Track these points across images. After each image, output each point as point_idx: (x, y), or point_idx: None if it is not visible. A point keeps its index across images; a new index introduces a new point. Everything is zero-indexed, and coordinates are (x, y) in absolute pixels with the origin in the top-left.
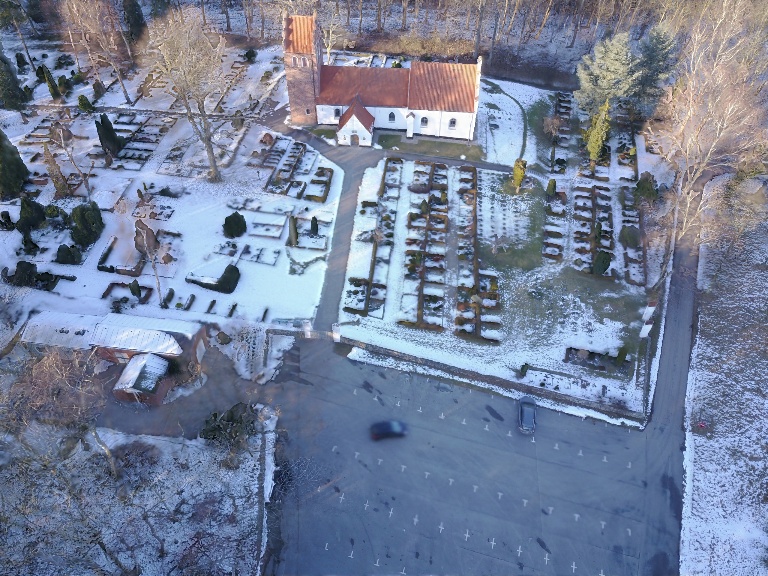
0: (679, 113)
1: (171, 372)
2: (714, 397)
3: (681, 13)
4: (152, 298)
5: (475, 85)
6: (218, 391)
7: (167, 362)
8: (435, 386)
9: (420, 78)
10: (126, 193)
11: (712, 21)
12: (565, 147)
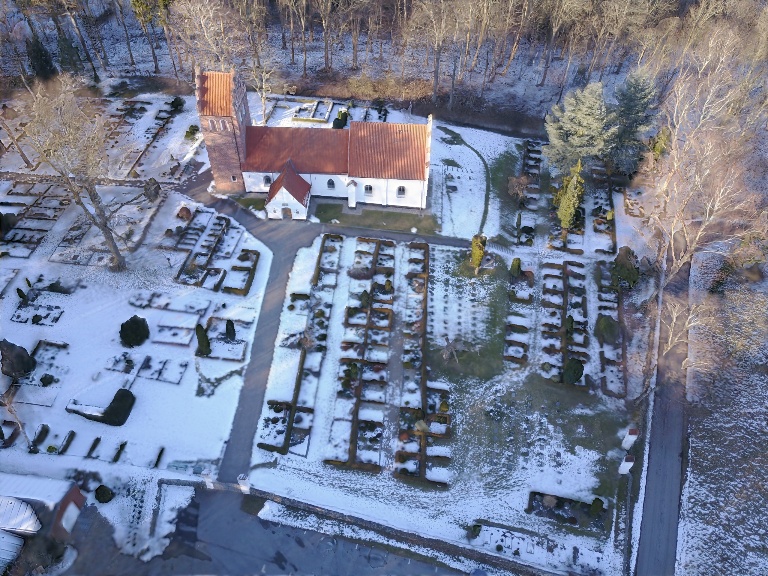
0: (662, 164)
1: (27, 554)
2: (710, 563)
3: (662, 51)
4: (21, 437)
5: (425, 148)
6: (89, 574)
7: (22, 540)
8: (365, 556)
9: (361, 141)
10: (7, 289)
11: (697, 63)
12: (533, 210)
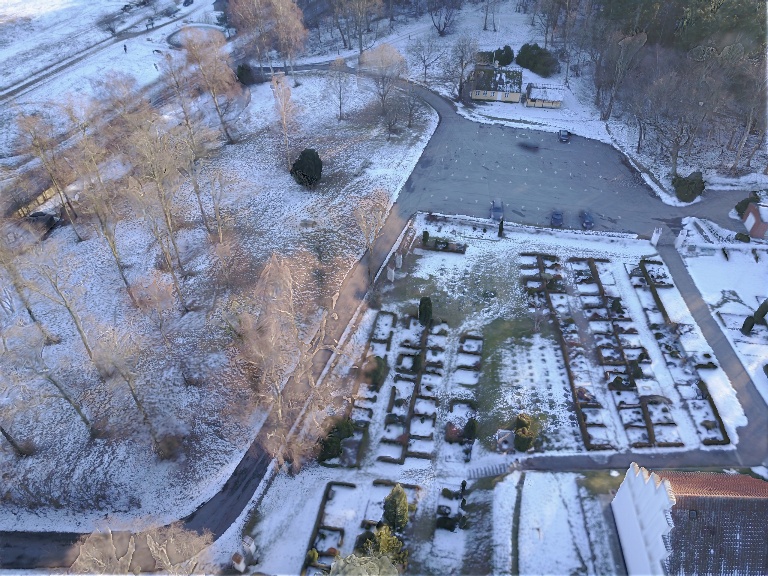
0: None
1: None
2: None
3: None
4: None
5: None
6: None
7: None
8: (564, 224)
9: (767, 487)
10: None
11: None
12: (433, 575)
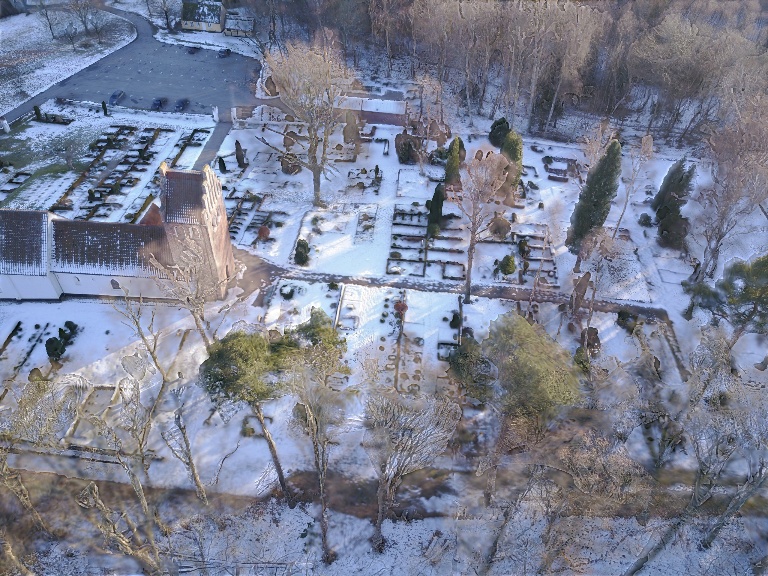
0: None
1: None
2: (0, 104)
3: None
4: None
5: None
6: None
7: None
8: (163, 108)
9: None
10: None
11: None
12: None
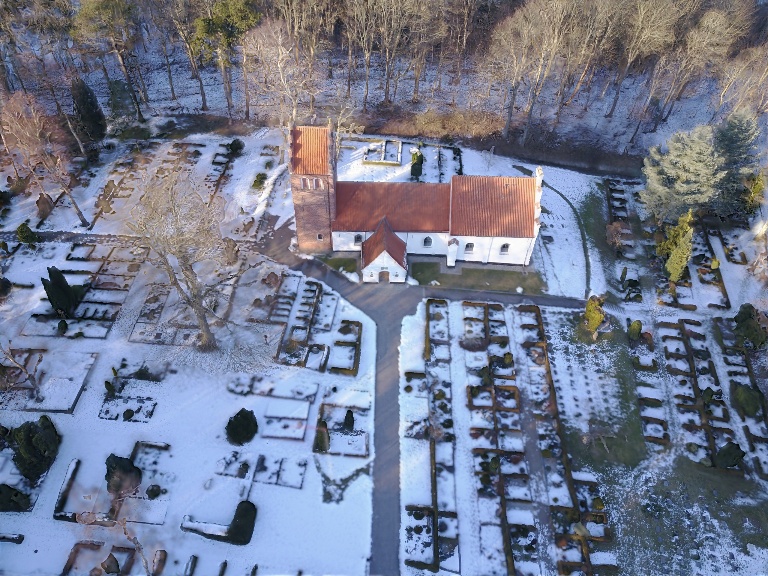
0: None
1: None
2: None
3: (747, 83)
4: (135, 567)
5: (534, 203)
6: None
7: None
8: None
9: (465, 196)
10: (89, 379)
11: None
12: (632, 260)
